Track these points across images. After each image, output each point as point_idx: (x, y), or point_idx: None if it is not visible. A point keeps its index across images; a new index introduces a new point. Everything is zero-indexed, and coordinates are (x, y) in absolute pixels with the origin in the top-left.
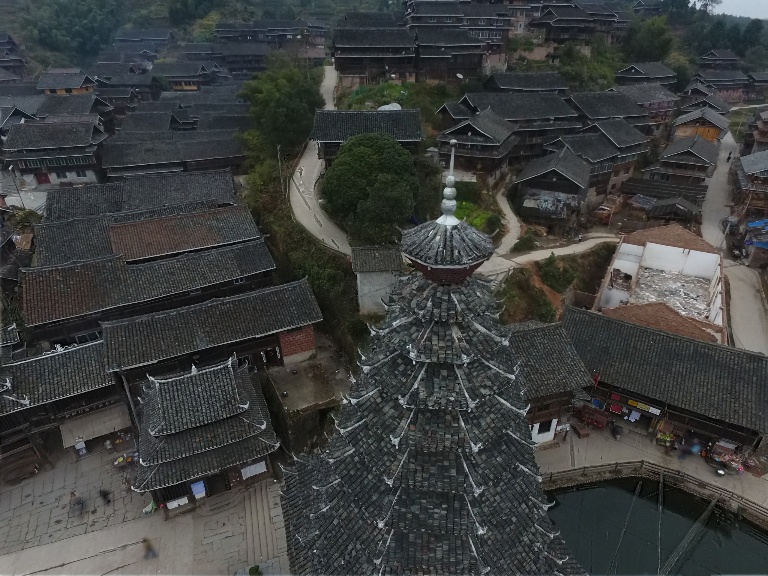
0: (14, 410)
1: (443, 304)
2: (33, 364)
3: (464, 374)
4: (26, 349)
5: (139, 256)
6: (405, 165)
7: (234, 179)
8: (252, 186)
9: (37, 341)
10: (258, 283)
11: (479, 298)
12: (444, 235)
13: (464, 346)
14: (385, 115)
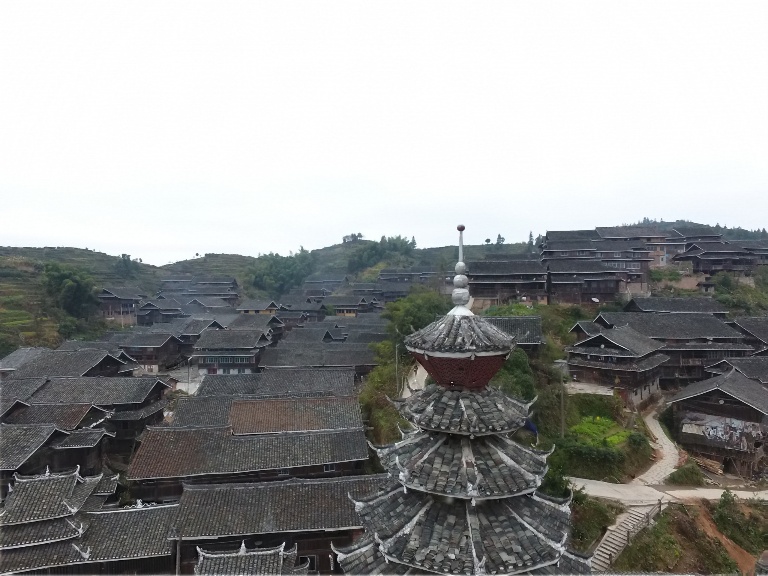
0: (73, 562)
1: (447, 410)
2: (112, 516)
3: (479, 525)
4: (118, 505)
5: (247, 431)
6: (516, 361)
7: (356, 377)
8: (370, 383)
9: (130, 498)
10: (348, 474)
11: (500, 412)
12: (451, 324)
13: (472, 472)
14: (504, 321)
